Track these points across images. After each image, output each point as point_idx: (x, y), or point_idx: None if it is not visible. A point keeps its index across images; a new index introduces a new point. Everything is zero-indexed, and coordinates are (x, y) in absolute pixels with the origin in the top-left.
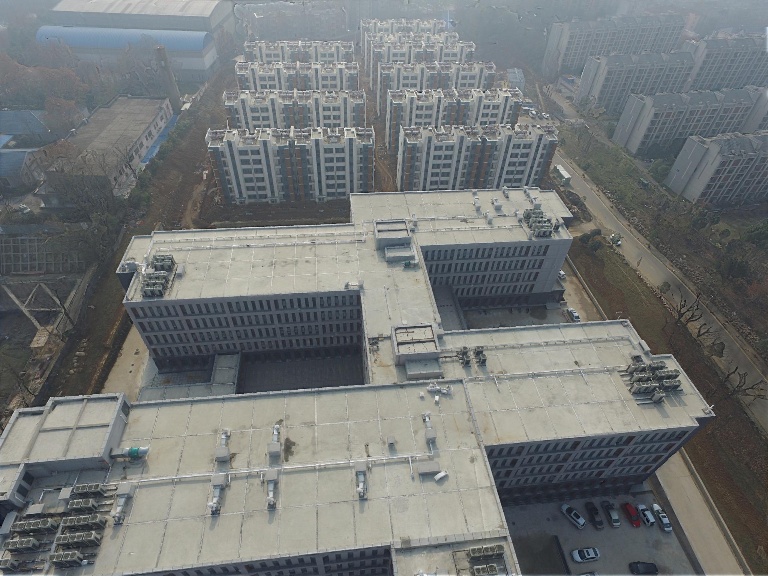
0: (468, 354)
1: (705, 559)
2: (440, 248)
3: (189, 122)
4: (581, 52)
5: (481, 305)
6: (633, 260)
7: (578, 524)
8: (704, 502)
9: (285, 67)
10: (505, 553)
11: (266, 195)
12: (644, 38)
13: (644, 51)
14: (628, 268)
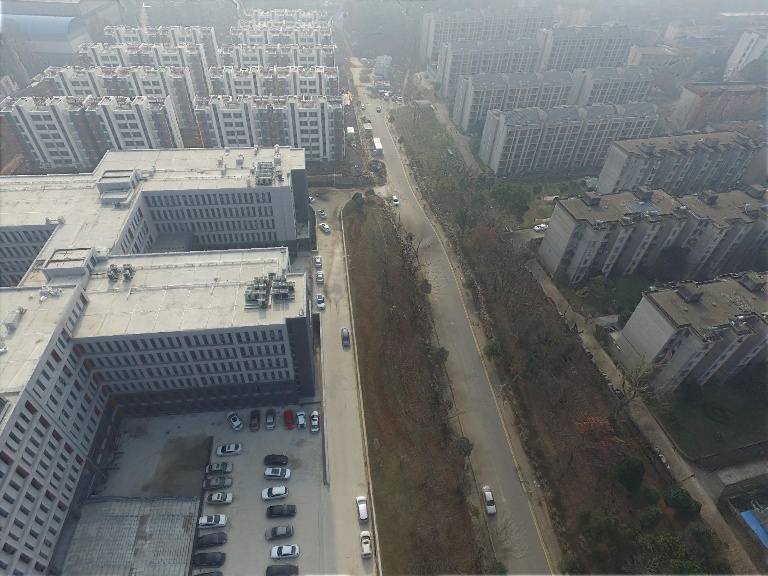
0: (121, 272)
1: (336, 453)
2: (163, 194)
3: None
4: None
5: None
6: (403, 217)
7: (233, 426)
8: (358, 409)
9: (129, 48)
10: (9, 402)
11: (71, 160)
12: (514, 28)
13: None
14: (386, 222)
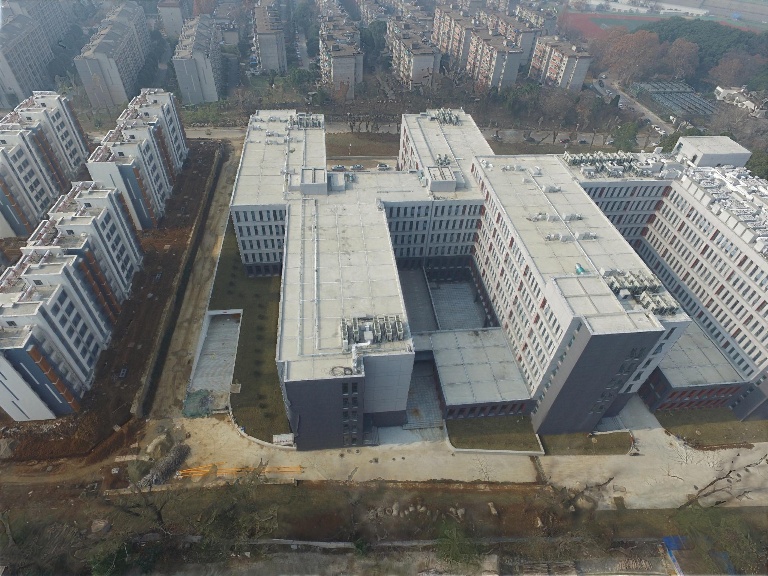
0: None
1: None
2: None
3: None
4: None
5: None
6: None
7: None
8: None
9: None
10: None
11: (97, 344)
12: None
13: None
14: None
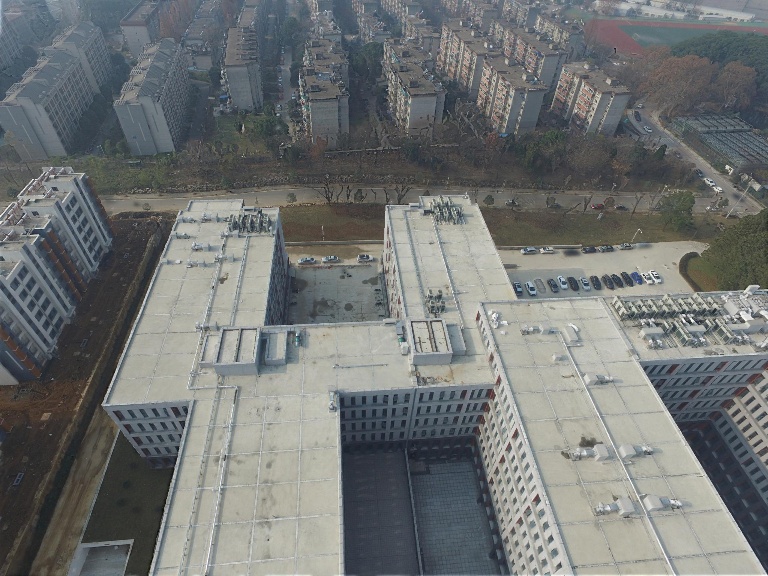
0: None
1: None
2: None
3: None
4: None
5: None
6: None
7: None
8: None
9: None
10: None
11: None
12: None
13: None
14: None
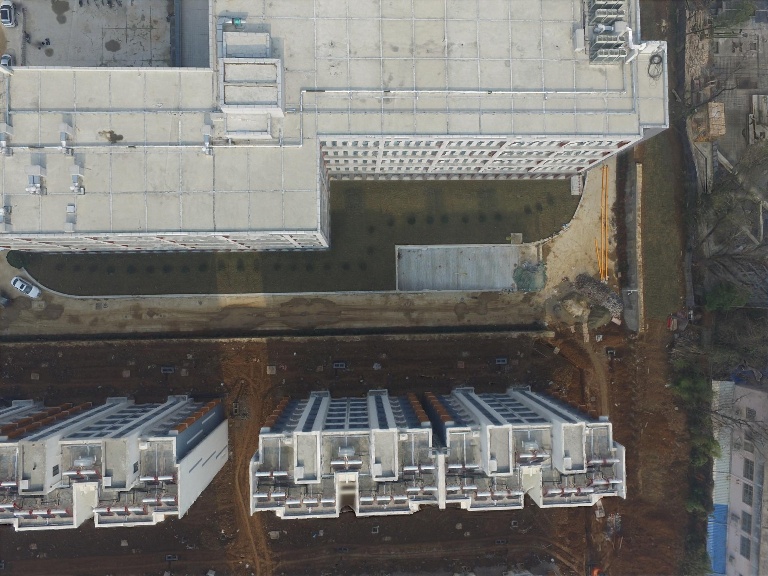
0: None
1: None
2: None
3: None
4: None
5: None
6: None
7: None
8: None
9: None
10: None
11: None
12: None
13: None
14: None
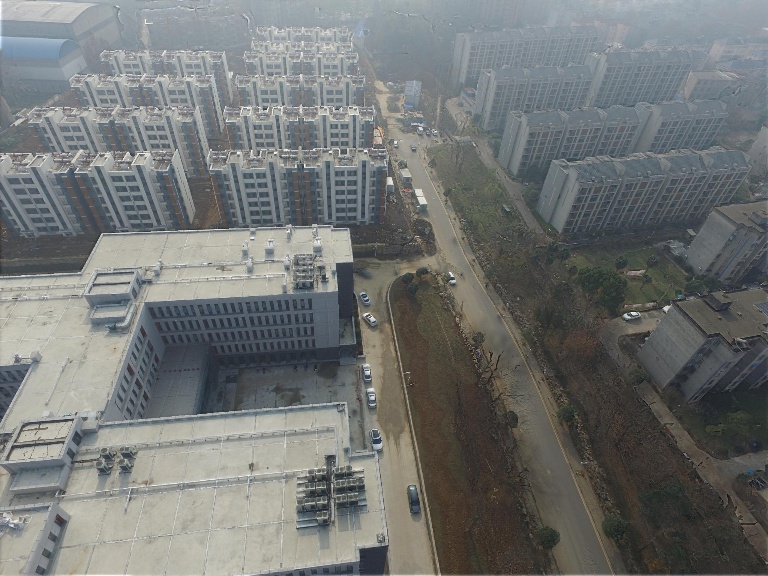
0: (117, 455)
1: None
2: (173, 304)
3: (13, 140)
4: (486, 64)
5: (261, 361)
6: None
7: None
8: None
9: (129, 80)
10: None
11: (58, 227)
12: (555, 49)
13: (538, 64)
14: (447, 314)
